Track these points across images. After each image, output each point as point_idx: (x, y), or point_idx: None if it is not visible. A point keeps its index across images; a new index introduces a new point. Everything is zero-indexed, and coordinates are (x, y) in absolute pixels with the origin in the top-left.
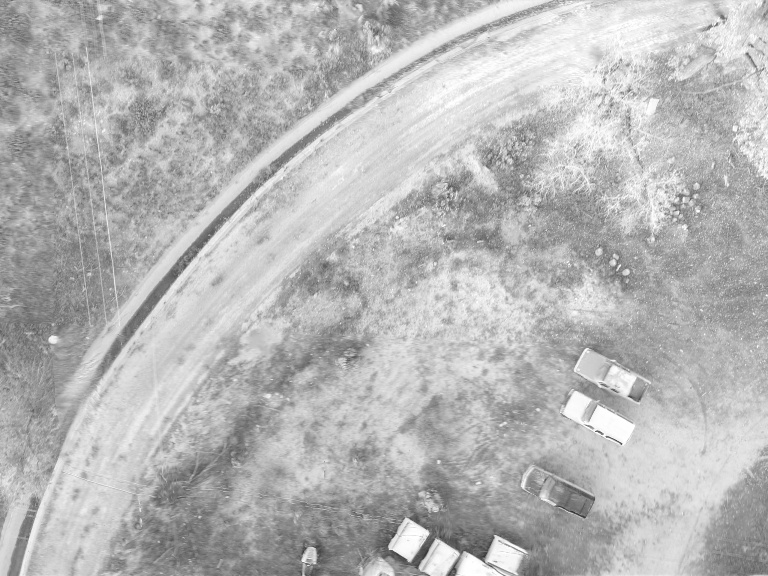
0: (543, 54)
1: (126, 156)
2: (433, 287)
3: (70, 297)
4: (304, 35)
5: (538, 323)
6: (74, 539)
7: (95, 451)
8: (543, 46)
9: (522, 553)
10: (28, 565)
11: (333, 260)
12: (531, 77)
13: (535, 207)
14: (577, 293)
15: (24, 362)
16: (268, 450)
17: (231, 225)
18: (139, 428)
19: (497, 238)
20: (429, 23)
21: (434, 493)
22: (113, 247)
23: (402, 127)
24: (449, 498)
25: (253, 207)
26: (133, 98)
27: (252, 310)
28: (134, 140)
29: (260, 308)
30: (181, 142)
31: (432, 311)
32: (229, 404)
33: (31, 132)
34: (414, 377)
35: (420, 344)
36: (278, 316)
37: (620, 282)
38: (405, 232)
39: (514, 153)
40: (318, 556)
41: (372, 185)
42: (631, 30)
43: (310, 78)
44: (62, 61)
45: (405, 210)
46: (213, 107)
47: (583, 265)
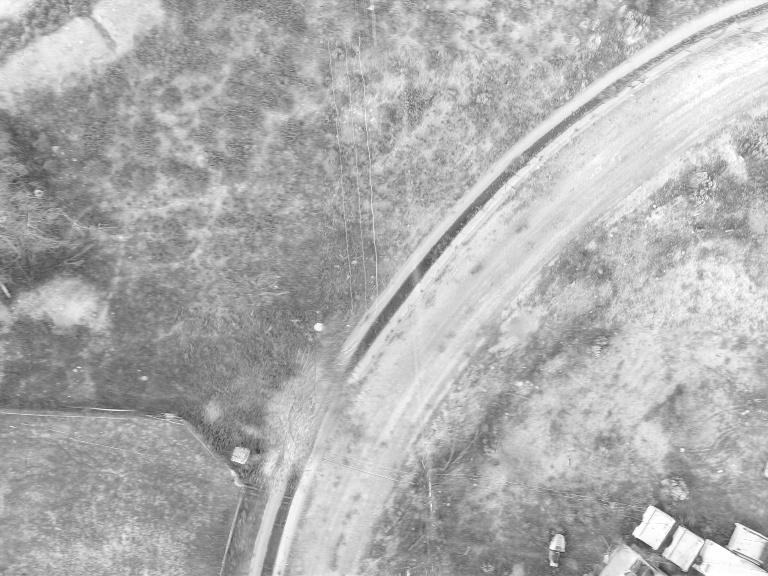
0: None
1: (394, 145)
2: (680, 276)
3: (335, 285)
4: (564, 25)
5: None
6: (336, 525)
7: (357, 438)
8: None
9: (765, 541)
10: (289, 551)
11: (591, 248)
12: None
13: None
14: None
15: (290, 349)
16: (515, 438)
17: (488, 214)
18: (401, 415)
19: (744, 227)
20: (684, 14)
21: (680, 481)
22: (376, 235)
23: (658, 117)
24: (692, 486)
25: (511, 196)
26: (402, 87)
27: (512, 298)
28: (403, 129)
29: (520, 296)
30: (445, 131)
31: (679, 300)
32: (484, 392)
33: (303, 121)
34: (659, 365)
35: (666, 333)
36: (537, 304)
37: None
38: (660, 221)
39: None
40: (566, 543)
41: (629, 174)
42: None
43: (568, 68)
44: (336, 50)
45: (662, 199)
46: (480, 96)
47: None
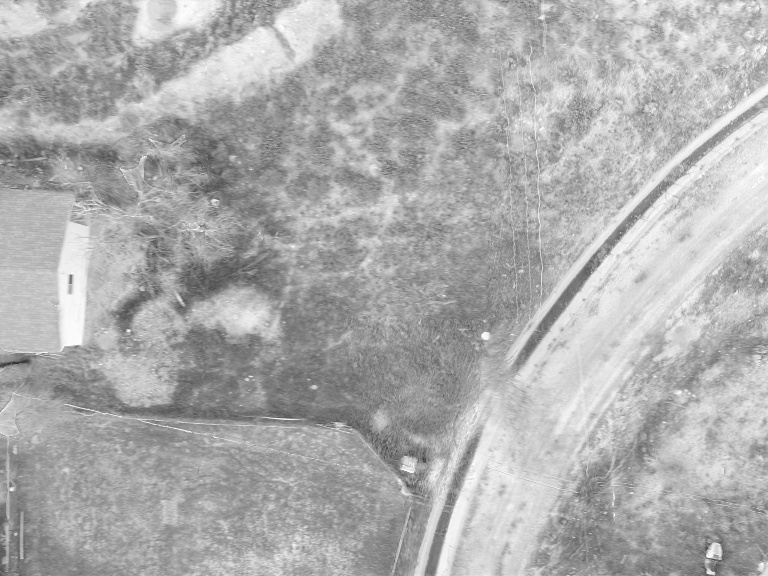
0: None
1: (562, 154)
2: None
3: (501, 294)
4: (728, 35)
5: None
6: (501, 534)
7: (522, 447)
8: None
9: None
10: (453, 560)
11: (754, 257)
12: None
13: None
14: None
15: (457, 358)
16: (671, 446)
17: (650, 223)
18: (565, 424)
19: None
20: None
21: None
22: (542, 244)
23: None
24: None
25: (673, 205)
26: (571, 97)
27: (676, 307)
28: (572, 138)
29: (684, 305)
30: (612, 140)
31: None
32: (645, 400)
33: (474, 130)
34: None
35: None
36: (701, 313)
37: None
38: None
39: None
40: (723, 552)
41: None
42: None
43: (731, 77)
44: (508, 60)
45: None
46: (649, 106)
47: None
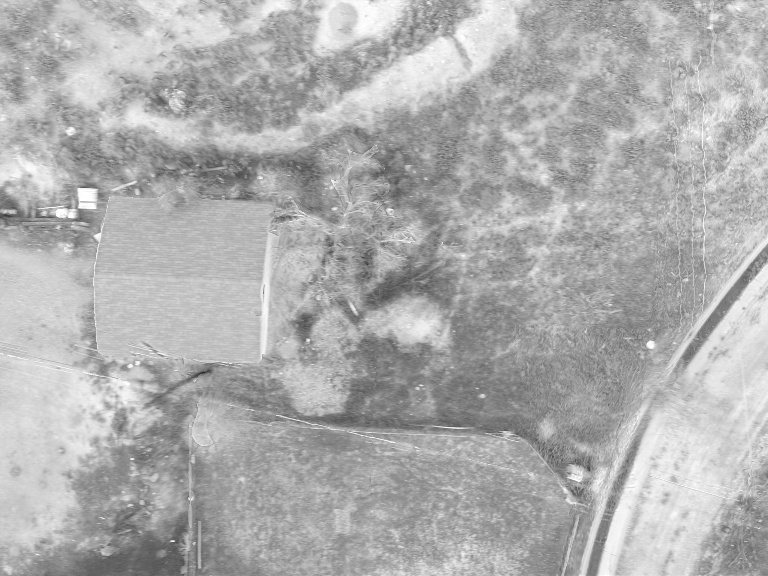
0: None
1: (728, 163)
2: None
3: (666, 303)
4: None
5: None
6: (664, 543)
7: (685, 455)
8: None
9: None
10: (616, 568)
11: None
12: None
13: None
14: None
15: (623, 367)
16: None
17: None
18: (728, 432)
19: None
20: None
21: None
22: (706, 253)
23: None
24: None
25: None
26: (737, 106)
27: None
28: (738, 147)
29: None
30: None
31: None
32: None
33: (643, 139)
34: None
35: None
36: None
37: None
38: None
39: None
40: None
41: None
42: None
43: None
44: (677, 69)
45: None
46: None
47: None
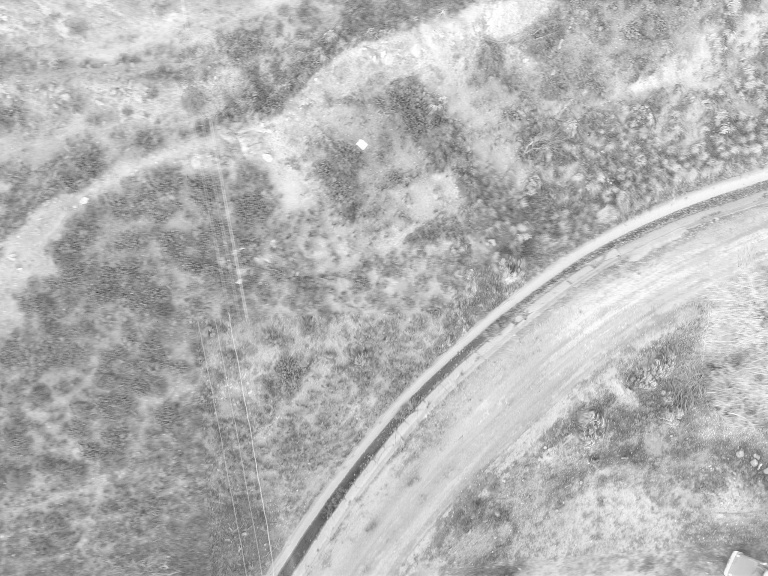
0: (676, 271)
1: (274, 415)
2: (580, 505)
3: (227, 558)
4: (439, 274)
5: (684, 529)
6: None
7: None
8: (675, 263)
9: None
10: None
11: (485, 496)
12: (667, 296)
13: (677, 420)
14: (722, 497)
15: None
16: None
17: (378, 467)
18: None
19: (640, 452)
20: (560, 249)
21: None
22: (265, 504)
23: (542, 356)
24: None
25: (400, 448)
26: (277, 357)
27: (408, 553)
28: (281, 399)
29: (416, 551)
30: (326, 394)
31: (581, 529)
32: None
33: (179, 402)
34: None
35: (571, 562)
36: (434, 557)
37: (763, 481)
38: (553, 460)
39: (658, 376)
40: None
41: (517, 417)
42: (761, 240)
43: (448, 315)
44: (206, 329)
45: (552, 439)
46: (358, 359)
47: (725, 468)
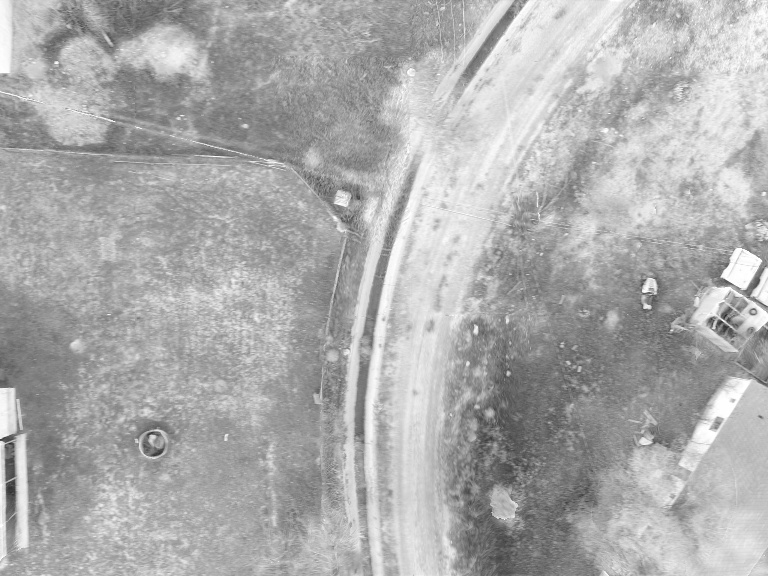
0: None
1: None
2: (753, 23)
3: (425, 31)
4: None
5: None
6: (437, 268)
7: (454, 181)
8: None
9: None
10: (392, 297)
11: None
12: None
13: None
14: None
15: (385, 95)
16: (602, 187)
17: None
18: (495, 157)
19: None
20: None
21: (764, 222)
22: None
23: None
24: None
25: None
26: None
27: (596, 40)
28: None
29: (604, 38)
30: None
31: (753, 46)
32: (573, 136)
33: None
34: (737, 112)
35: (742, 79)
36: (620, 45)
37: None
38: None
39: None
40: (658, 286)
41: None
42: None
43: None
44: None
45: None
46: None
47: None
